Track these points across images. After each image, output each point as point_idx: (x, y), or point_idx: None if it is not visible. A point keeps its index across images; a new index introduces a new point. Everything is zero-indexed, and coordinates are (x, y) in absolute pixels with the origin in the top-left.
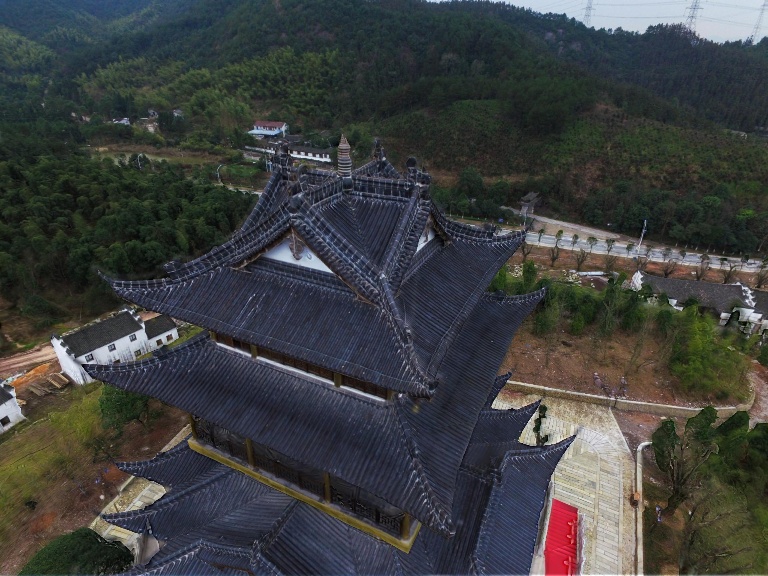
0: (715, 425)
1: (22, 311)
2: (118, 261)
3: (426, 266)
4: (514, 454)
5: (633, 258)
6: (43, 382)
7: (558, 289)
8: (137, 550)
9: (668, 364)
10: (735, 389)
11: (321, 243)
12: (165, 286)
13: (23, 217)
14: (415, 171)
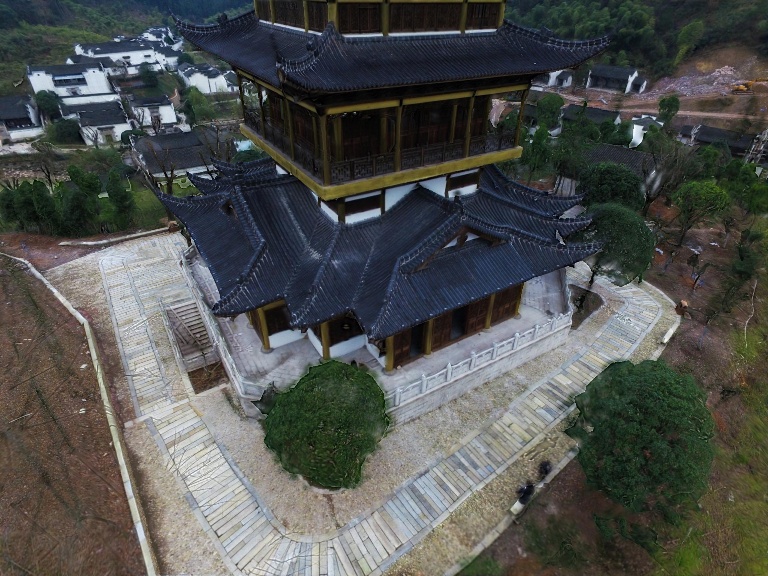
0: None
1: None
2: None
3: None
4: None
5: None
6: None
7: None
8: (568, 291)
9: None
10: None
11: None
12: None
13: None
14: None
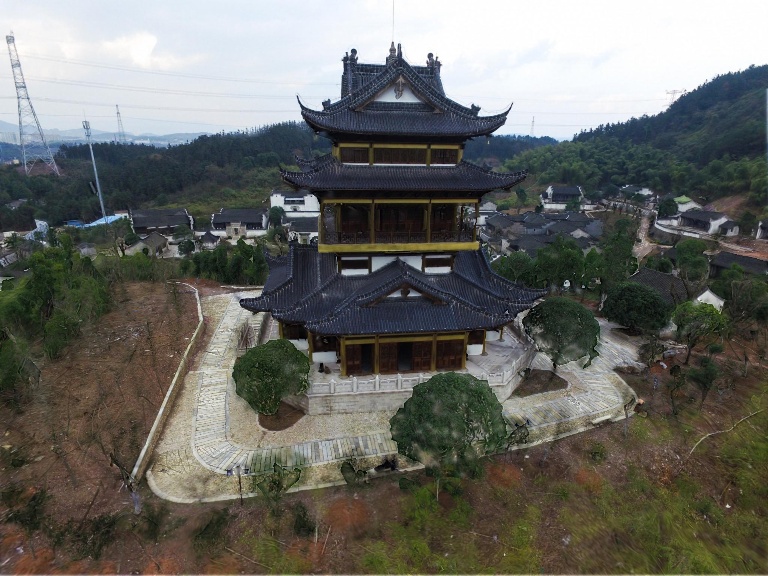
0: None
1: None
2: None
3: None
4: None
5: None
6: None
7: None
8: None
9: None
10: None
11: None
12: None
13: None
14: None
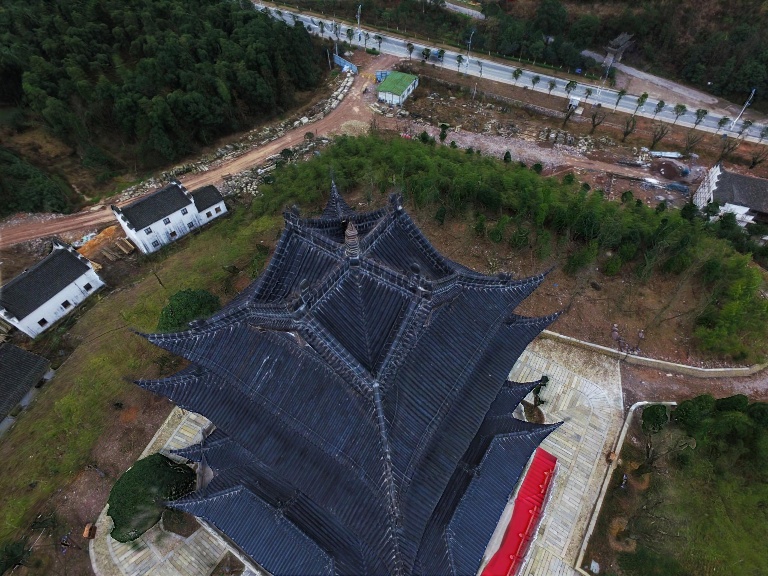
0: (720, 385)
1: (82, 160)
2: (162, 115)
3: (428, 333)
4: (502, 437)
5: (723, 135)
6: (113, 246)
7: (606, 217)
8: None
9: (693, 325)
10: (758, 347)
11: (322, 344)
12: (192, 336)
13: (63, 52)
14: (418, 277)
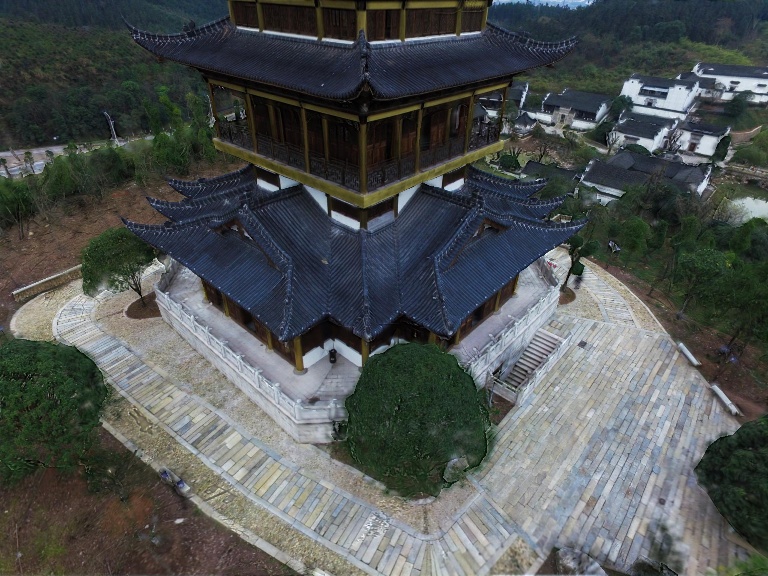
0: None
1: None
2: None
3: None
4: None
5: None
6: None
7: None
8: None
9: None
10: None
11: None
12: None
13: None
14: None
